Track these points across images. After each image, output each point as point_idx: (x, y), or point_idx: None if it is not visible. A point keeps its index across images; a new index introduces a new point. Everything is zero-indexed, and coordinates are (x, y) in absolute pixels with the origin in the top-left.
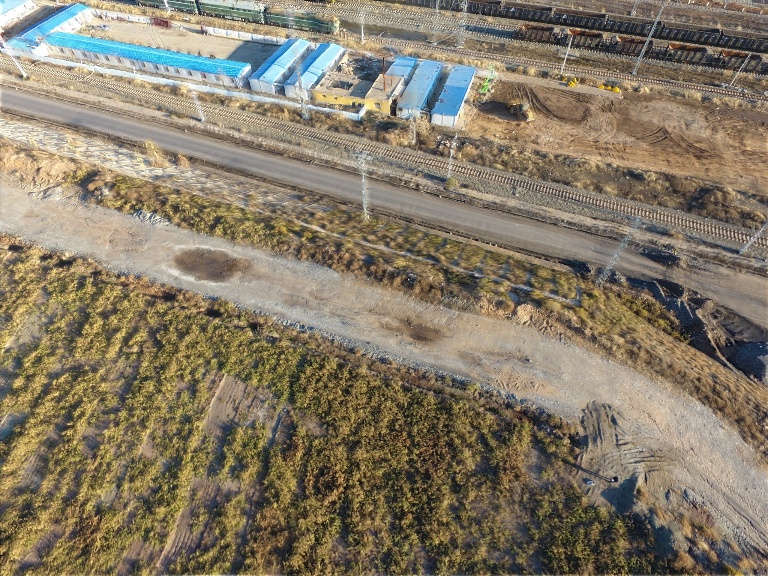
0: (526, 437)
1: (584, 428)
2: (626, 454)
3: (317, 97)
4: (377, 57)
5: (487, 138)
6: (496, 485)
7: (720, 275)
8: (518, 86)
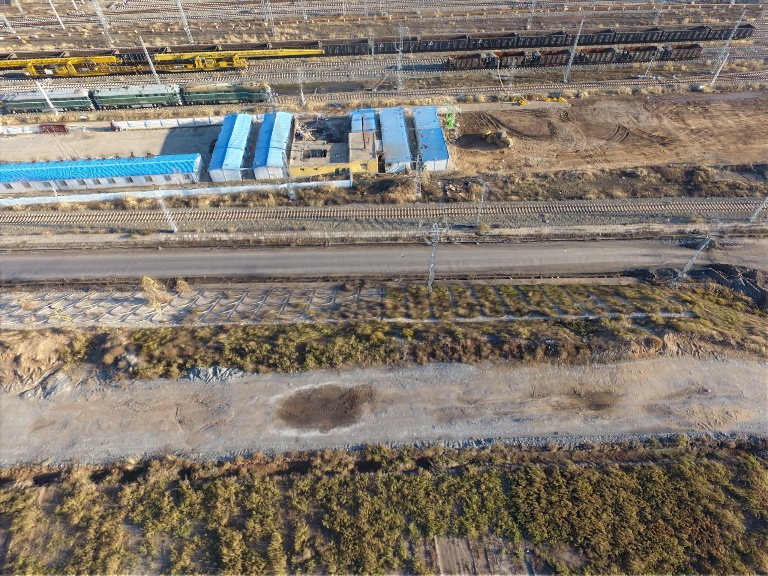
0: (765, 473)
1: None
2: None
3: (295, 172)
4: (326, 115)
5: (484, 172)
6: None
7: (748, 245)
8: (477, 115)
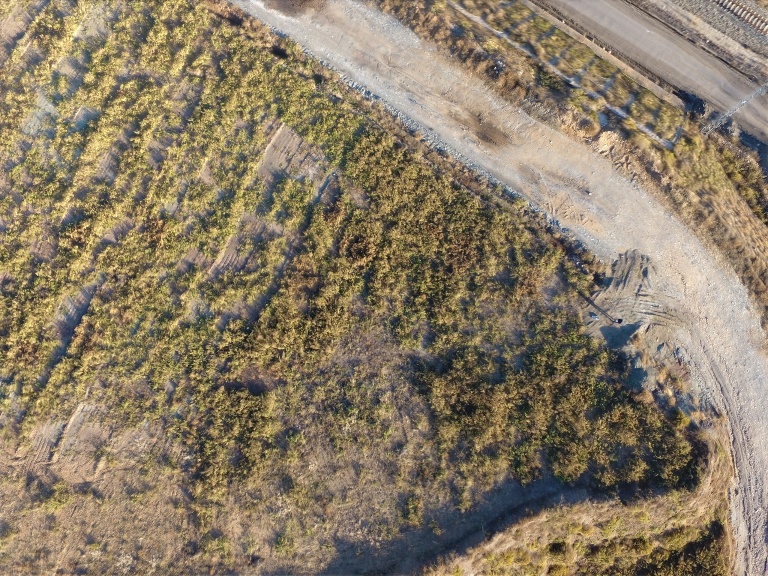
0: (554, 263)
1: (613, 271)
2: (641, 304)
3: None
4: None
5: None
6: (509, 294)
7: None
8: None
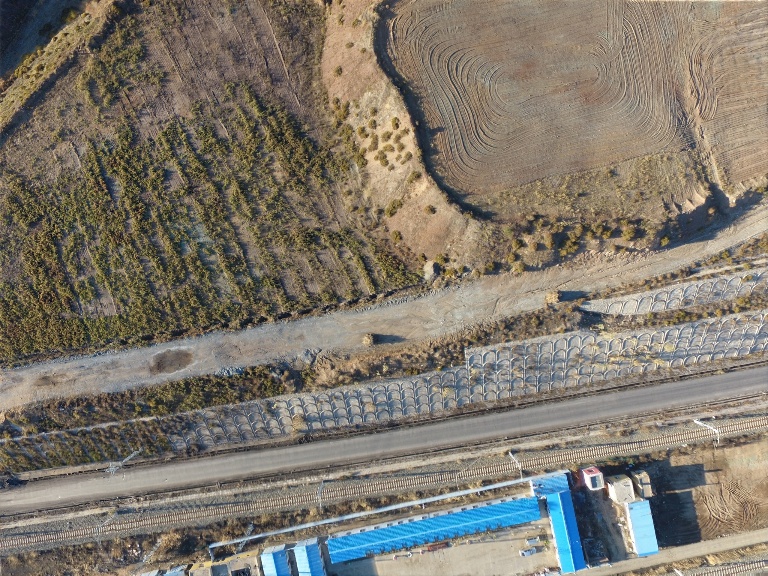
0: None
1: None
2: None
3: None
4: None
5: (112, 574)
6: None
7: None
8: None
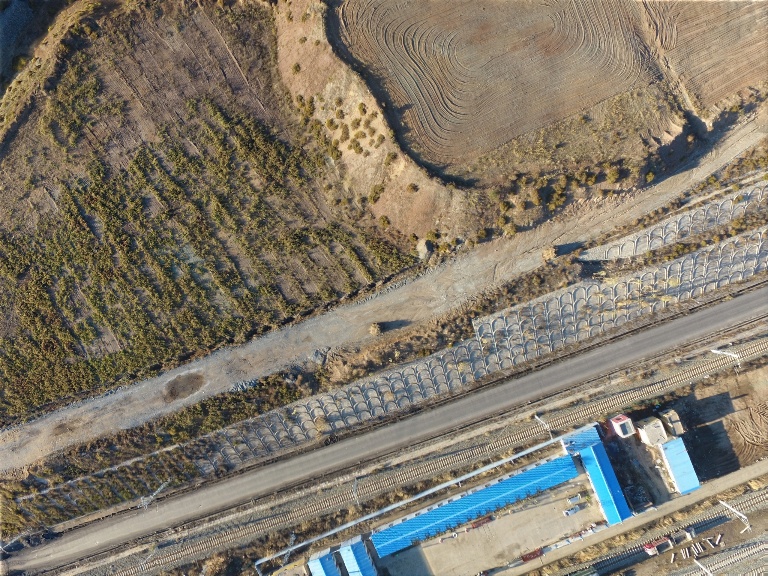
0: None
1: None
2: None
3: None
4: None
5: None
6: None
7: None
8: None
